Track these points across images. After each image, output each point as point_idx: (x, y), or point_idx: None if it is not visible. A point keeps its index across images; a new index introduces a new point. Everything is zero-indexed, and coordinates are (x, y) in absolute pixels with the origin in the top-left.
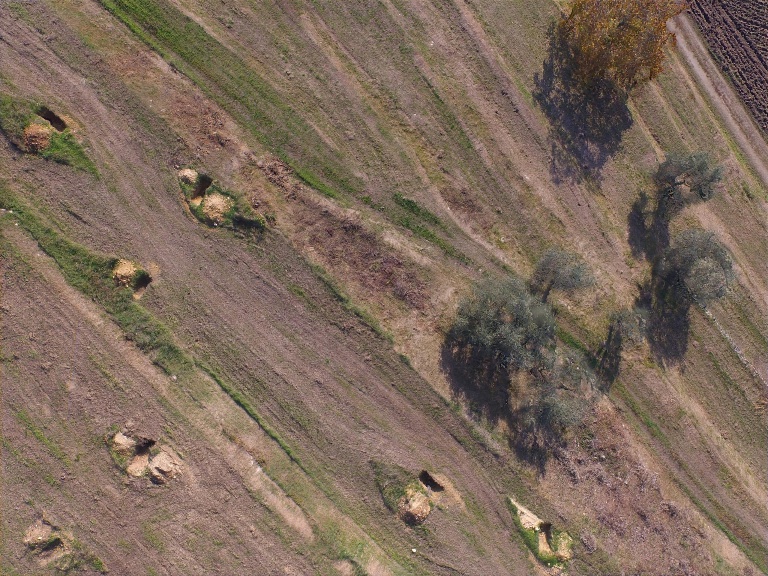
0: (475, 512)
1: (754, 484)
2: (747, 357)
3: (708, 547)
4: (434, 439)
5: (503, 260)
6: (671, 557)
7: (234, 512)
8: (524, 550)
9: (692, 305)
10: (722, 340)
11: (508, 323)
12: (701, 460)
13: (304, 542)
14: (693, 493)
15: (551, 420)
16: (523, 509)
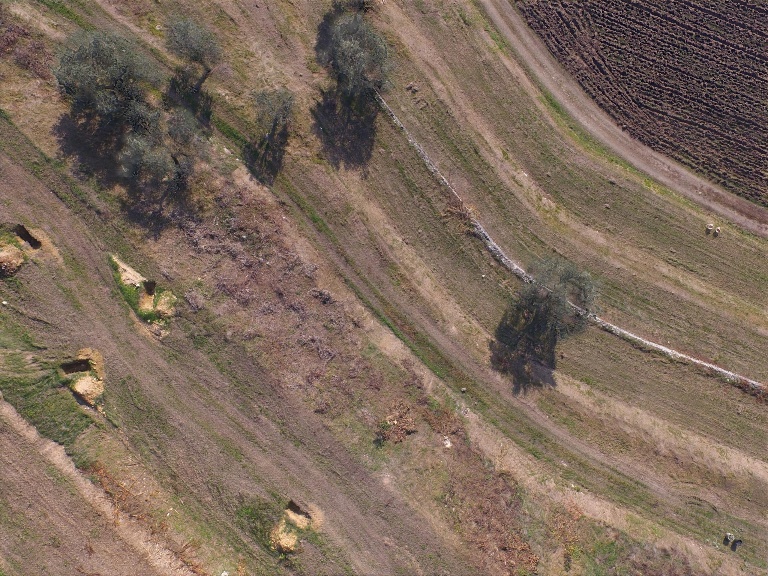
0: (74, 268)
1: (431, 286)
2: (441, 170)
3: (362, 335)
4: (33, 194)
5: (152, 44)
6: (304, 333)
7: None
8: (125, 307)
9: (380, 113)
10: (409, 148)
11: (89, 65)
12: (369, 256)
13: None
14: (359, 289)
15: (187, 197)
16: (126, 267)
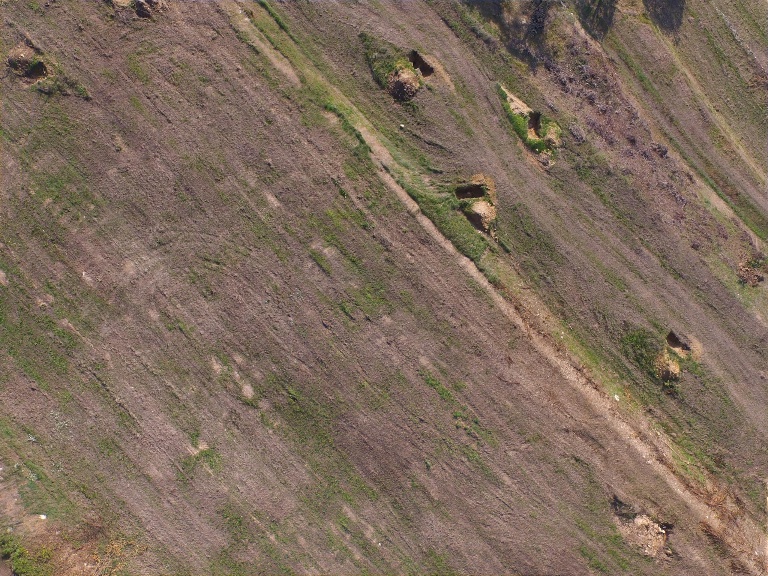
0: (464, 95)
1: (744, 152)
2: None
3: (696, 191)
4: (425, 21)
5: None
6: (659, 178)
7: (221, 51)
8: (513, 136)
9: None
10: (717, 17)
11: None
12: (692, 117)
13: (291, 86)
14: (683, 149)
15: (543, 42)
16: (513, 97)
